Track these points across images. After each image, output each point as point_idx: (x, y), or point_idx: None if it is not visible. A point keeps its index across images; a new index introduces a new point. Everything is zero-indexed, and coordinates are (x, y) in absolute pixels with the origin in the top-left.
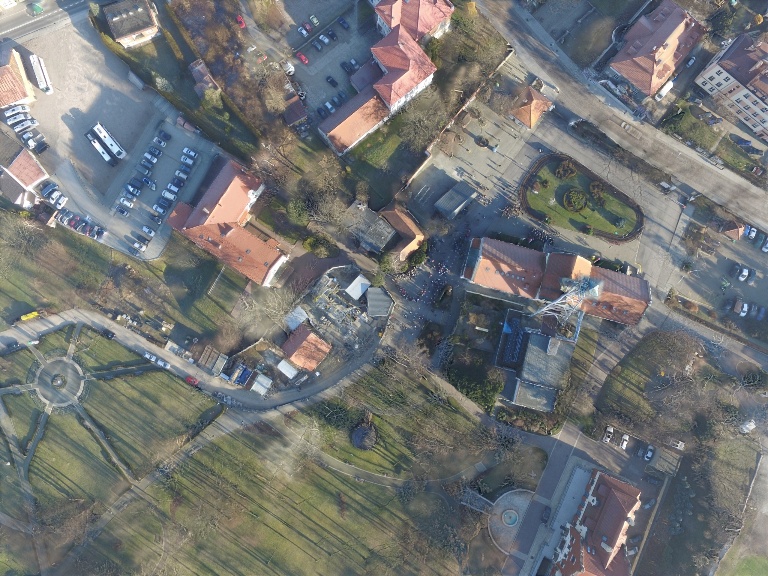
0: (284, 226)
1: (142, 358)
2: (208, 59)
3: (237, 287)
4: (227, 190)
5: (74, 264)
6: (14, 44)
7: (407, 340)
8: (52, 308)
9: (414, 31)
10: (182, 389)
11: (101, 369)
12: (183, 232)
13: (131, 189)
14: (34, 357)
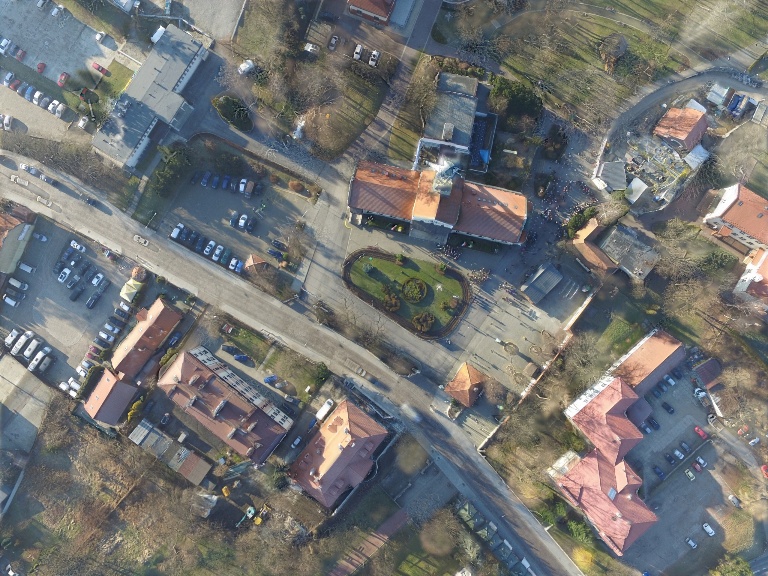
0: None
1: None
2: None
3: (752, 189)
4: None
5: None
6: None
7: (577, 143)
8: None
9: (600, 458)
10: None
11: None
12: None
13: None
14: None
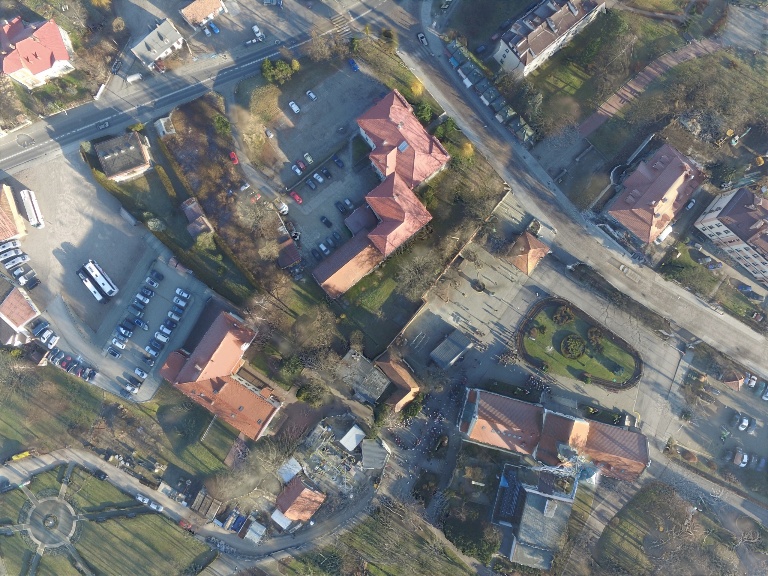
0: (278, 372)
1: (135, 500)
2: (201, 196)
3: (230, 434)
4: (219, 346)
5: (66, 403)
6: (5, 175)
7: (402, 489)
8: (44, 448)
9: (409, 180)
10: (175, 532)
11: (93, 510)
12: (175, 386)
13: (123, 331)
14: (26, 497)
